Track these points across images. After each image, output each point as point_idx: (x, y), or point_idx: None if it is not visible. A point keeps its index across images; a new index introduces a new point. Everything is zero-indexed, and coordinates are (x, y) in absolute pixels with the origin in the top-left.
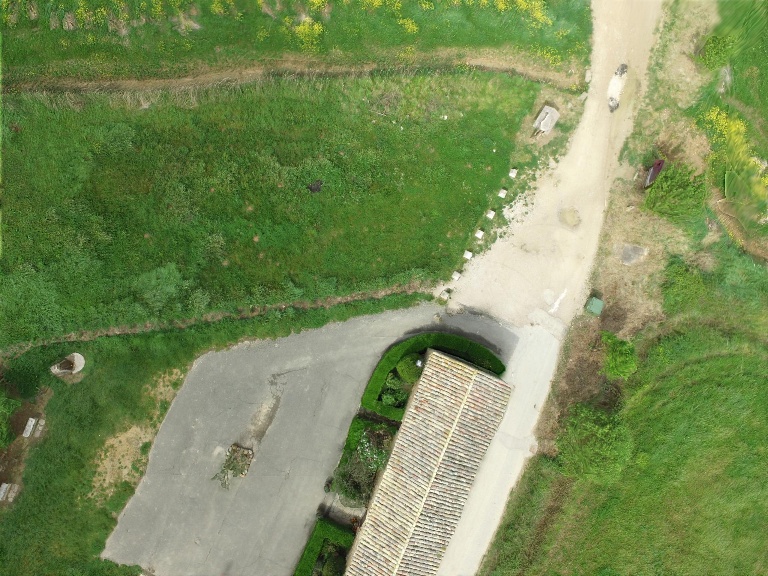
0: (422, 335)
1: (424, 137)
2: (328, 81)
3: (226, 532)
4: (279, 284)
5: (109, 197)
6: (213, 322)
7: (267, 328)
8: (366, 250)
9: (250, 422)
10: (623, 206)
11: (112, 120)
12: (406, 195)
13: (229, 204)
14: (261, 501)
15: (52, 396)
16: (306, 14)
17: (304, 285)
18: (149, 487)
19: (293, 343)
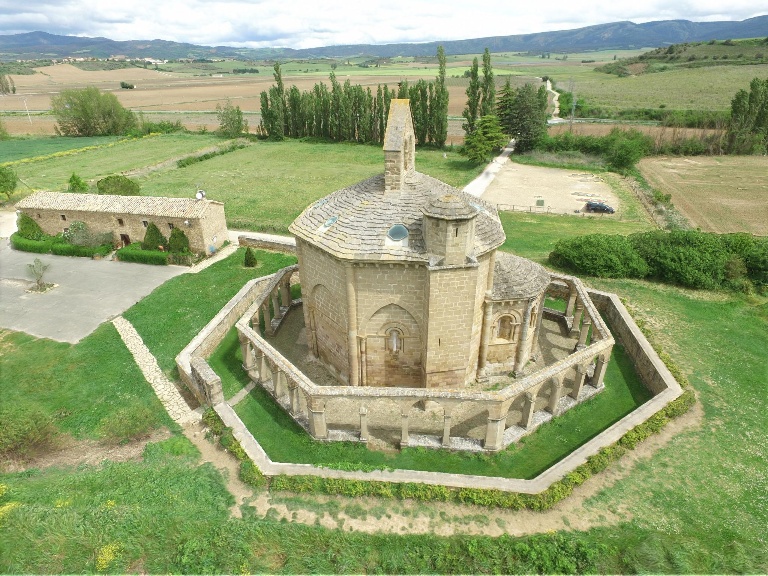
0: None
1: None
2: None
3: (101, 289)
4: None
5: None
6: None
7: None
8: None
9: None
10: (3, 208)
11: None
12: None
13: None
14: None
15: None
16: None
17: None
18: None
19: None
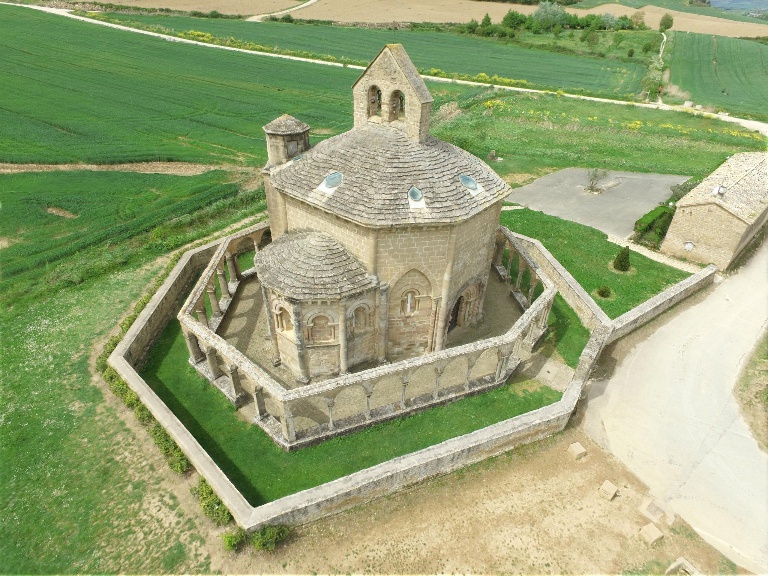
0: None
1: None
2: None
3: None
4: None
5: (530, 136)
6: None
7: (612, 168)
8: None
9: None
10: None
11: None
12: None
13: None
14: (609, 202)
15: None
16: None
17: None
18: None
19: (629, 173)
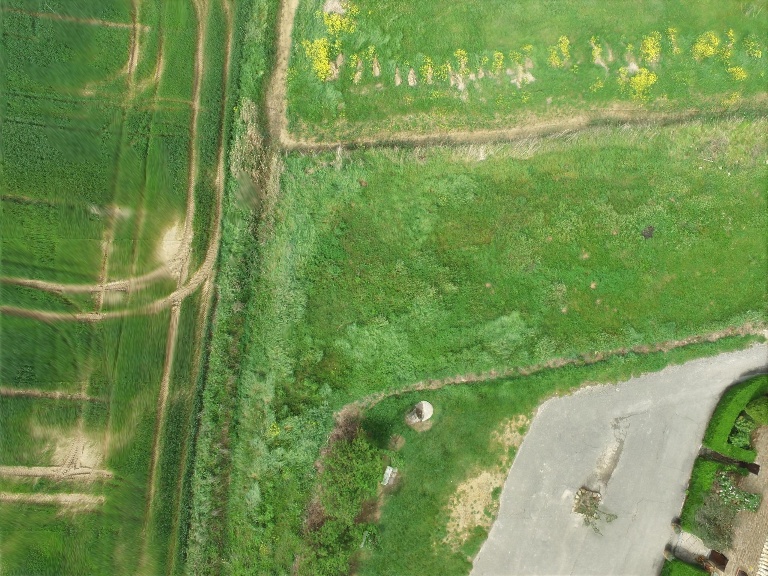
0: (766, 378)
1: (750, 182)
2: (660, 130)
3: (578, 574)
4: (618, 330)
5: (452, 248)
6: (557, 368)
7: (608, 373)
8: (699, 294)
9: (596, 465)
10: None
11: (454, 172)
12: (735, 239)
13: (566, 252)
14: (610, 543)
15: (404, 444)
16: (639, 65)
17: (643, 330)
18: (502, 531)
19: (633, 387)
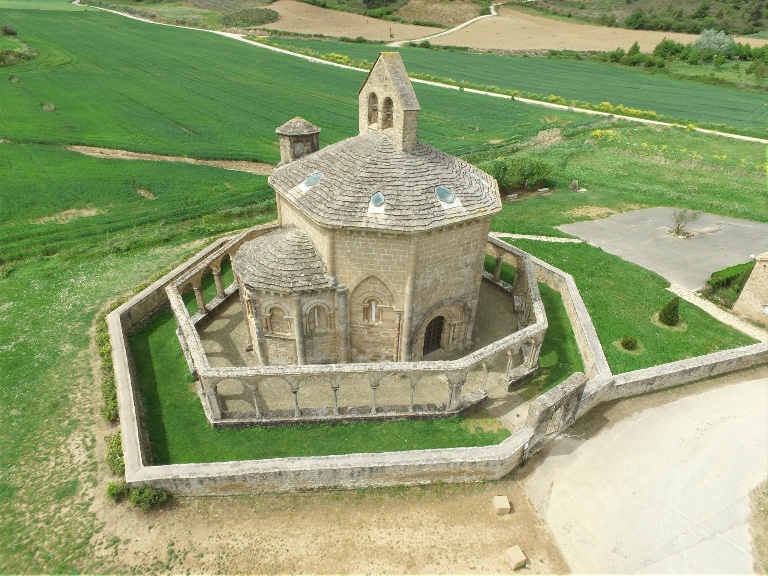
0: None
1: None
2: None
3: None
4: None
5: None
6: None
7: (719, 212)
8: None
9: None
10: None
11: None
12: None
13: None
14: (694, 249)
15: None
16: None
17: None
18: None
19: (739, 220)
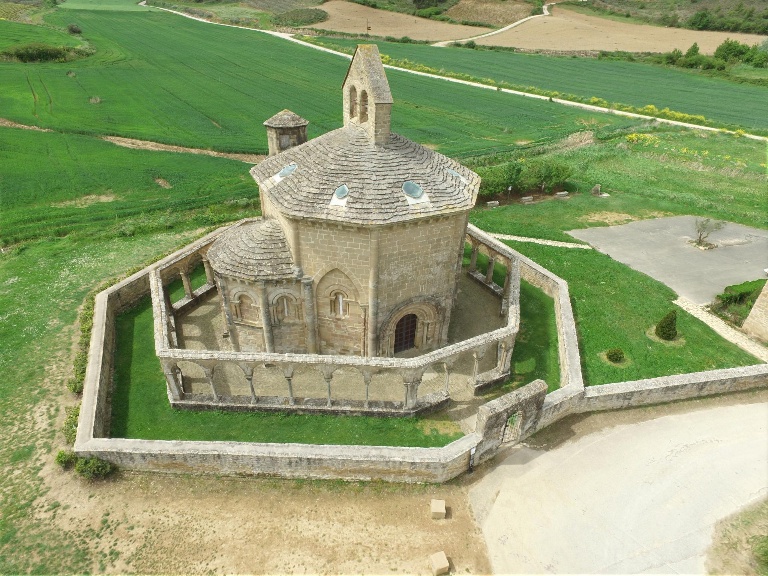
0: None
1: None
2: None
3: None
4: None
5: None
6: None
7: (752, 224)
8: None
9: (720, 239)
10: None
11: None
12: None
13: None
14: (714, 261)
15: None
16: None
17: None
18: None
19: None
